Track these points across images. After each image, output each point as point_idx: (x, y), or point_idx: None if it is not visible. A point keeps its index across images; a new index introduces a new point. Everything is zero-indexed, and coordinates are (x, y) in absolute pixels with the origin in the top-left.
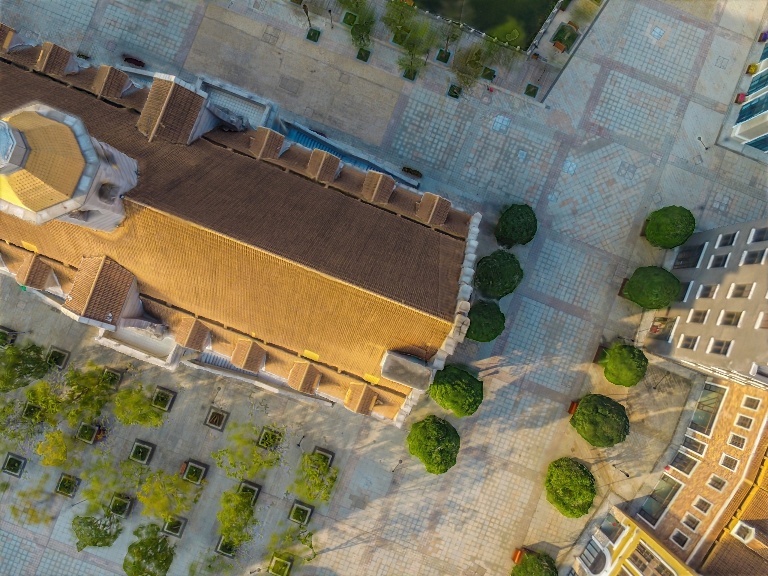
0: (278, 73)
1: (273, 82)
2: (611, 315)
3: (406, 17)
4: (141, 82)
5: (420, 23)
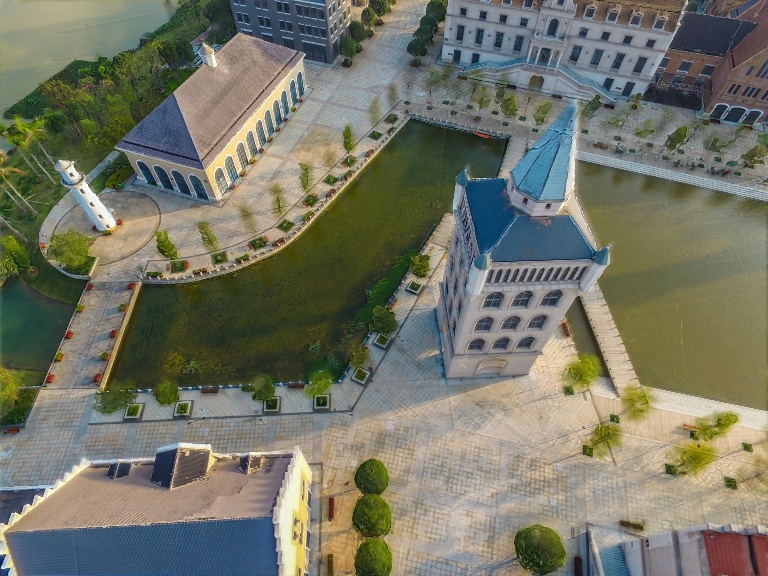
0: (536, 106)
1: (538, 104)
2: (366, 45)
3: (476, 125)
4: (585, 20)
5: (468, 124)
